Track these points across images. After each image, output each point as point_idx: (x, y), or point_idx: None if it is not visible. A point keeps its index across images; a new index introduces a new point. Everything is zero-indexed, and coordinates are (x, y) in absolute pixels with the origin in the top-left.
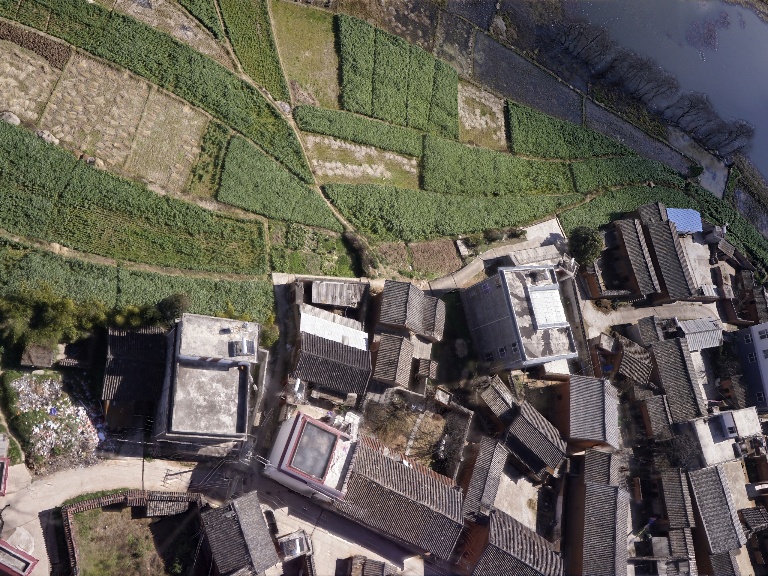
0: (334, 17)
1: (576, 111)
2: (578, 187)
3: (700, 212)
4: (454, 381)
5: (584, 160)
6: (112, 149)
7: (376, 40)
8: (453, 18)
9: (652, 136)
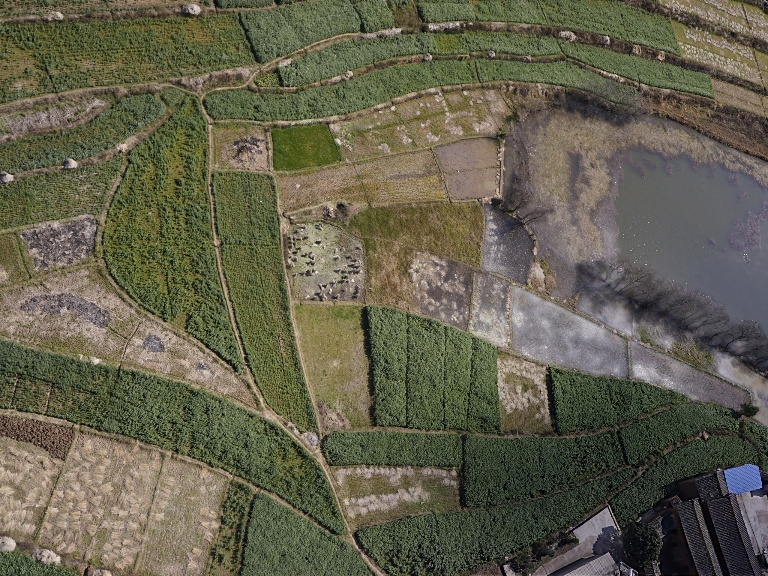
0: (363, 310)
1: (621, 360)
2: (629, 459)
3: (757, 457)
4: None
5: (633, 422)
6: (121, 549)
7: (409, 329)
8: (489, 278)
9: (701, 370)
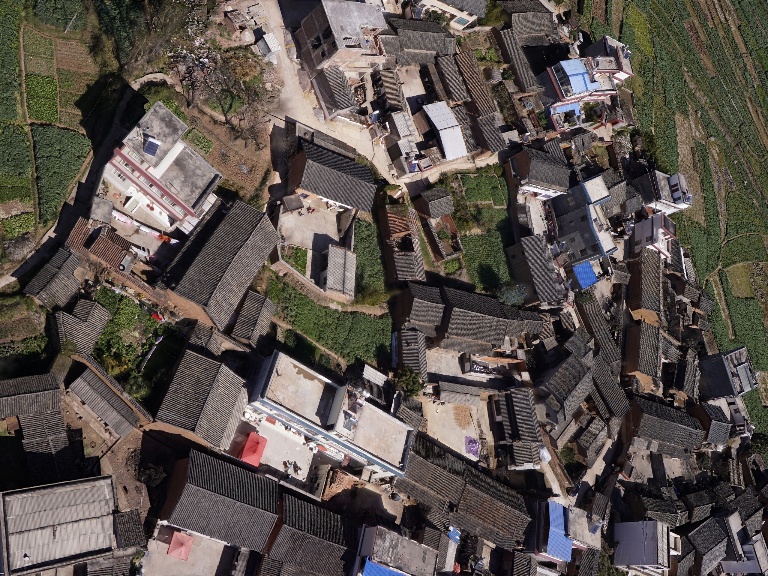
0: None
1: None
2: None
3: None
4: (683, 340)
5: None
6: None
7: (760, 320)
8: None
9: None
